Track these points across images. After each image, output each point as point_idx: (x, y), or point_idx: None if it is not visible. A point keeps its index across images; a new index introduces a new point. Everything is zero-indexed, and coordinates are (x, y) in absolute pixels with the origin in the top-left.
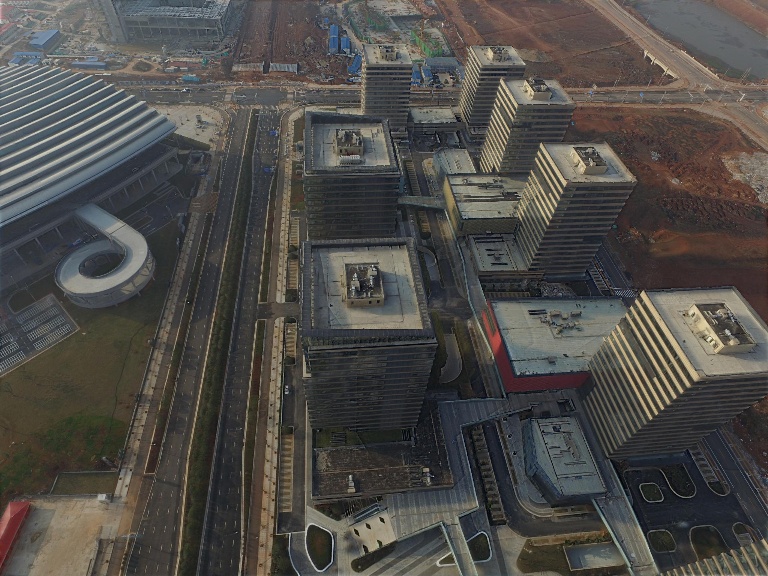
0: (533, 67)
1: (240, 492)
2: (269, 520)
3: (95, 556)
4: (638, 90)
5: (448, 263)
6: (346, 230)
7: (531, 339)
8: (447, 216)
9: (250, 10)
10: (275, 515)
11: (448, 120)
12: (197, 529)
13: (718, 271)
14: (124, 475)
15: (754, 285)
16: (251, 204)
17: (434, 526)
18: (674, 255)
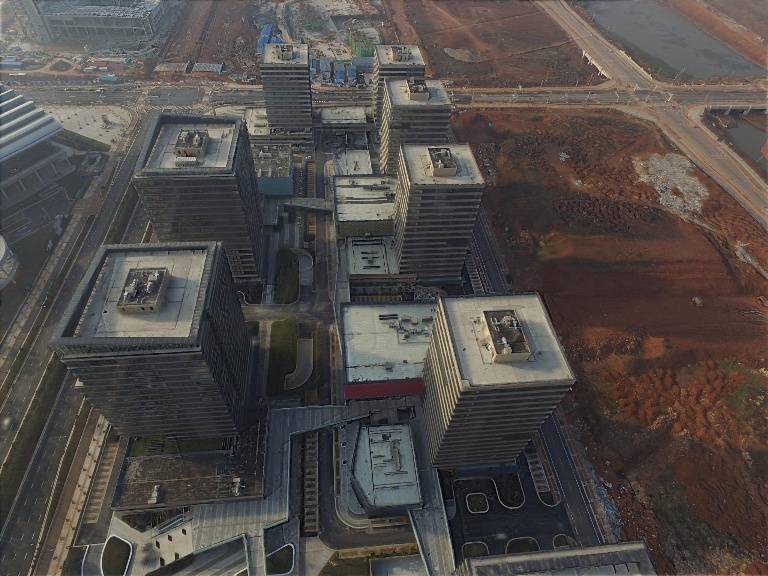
0: (464, 67)
1: (47, 502)
2: (70, 531)
3: None
4: (566, 90)
5: (325, 266)
6: (196, 233)
7: (374, 345)
8: (333, 218)
9: (188, 10)
10: (77, 526)
11: (358, 121)
12: None
13: (599, 274)
14: None
15: (635, 289)
16: (137, 206)
17: (235, 538)
18: (556, 258)
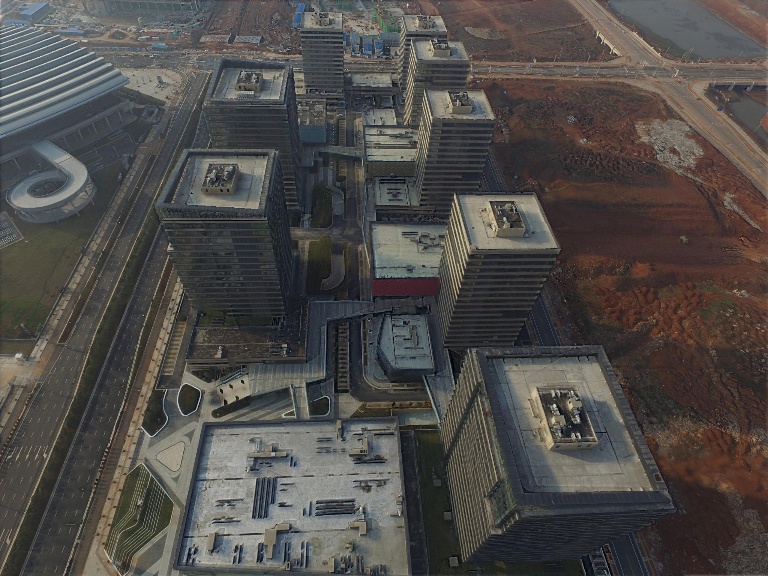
0: (483, 43)
1: (132, 359)
2: (152, 379)
3: (6, 395)
4: (578, 65)
5: (355, 201)
6: None
7: (398, 253)
8: (362, 163)
9: None
10: (157, 376)
11: (385, 85)
12: (91, 381)
13: (596, 214)
14: (41, 343)
15: (628, 227)
16: None
17: (284, 387)
18: (558, 199)
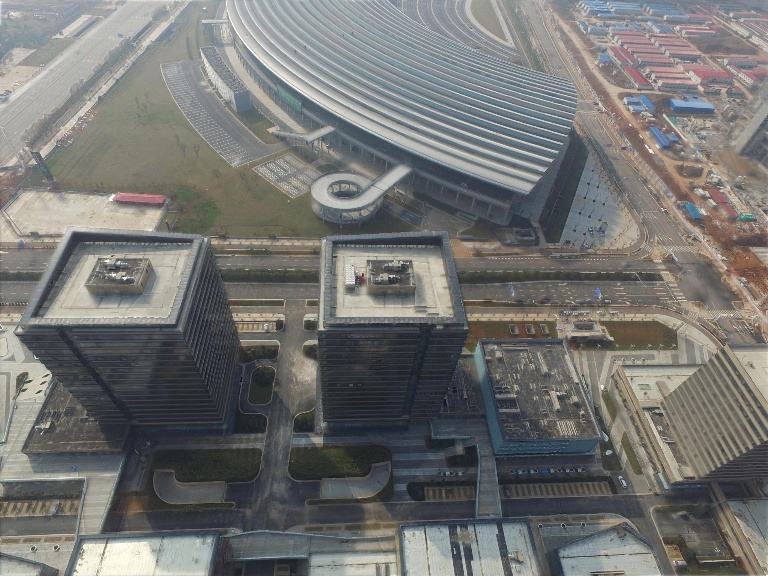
0: None
1: None
2: None
3: None
4: None
5: (356, 519)
6: None
7: None
8: None
9: None
10: None
11: None
12: None
13: None
14: None
15: None
16: None
17: (6, 434)
18: None
